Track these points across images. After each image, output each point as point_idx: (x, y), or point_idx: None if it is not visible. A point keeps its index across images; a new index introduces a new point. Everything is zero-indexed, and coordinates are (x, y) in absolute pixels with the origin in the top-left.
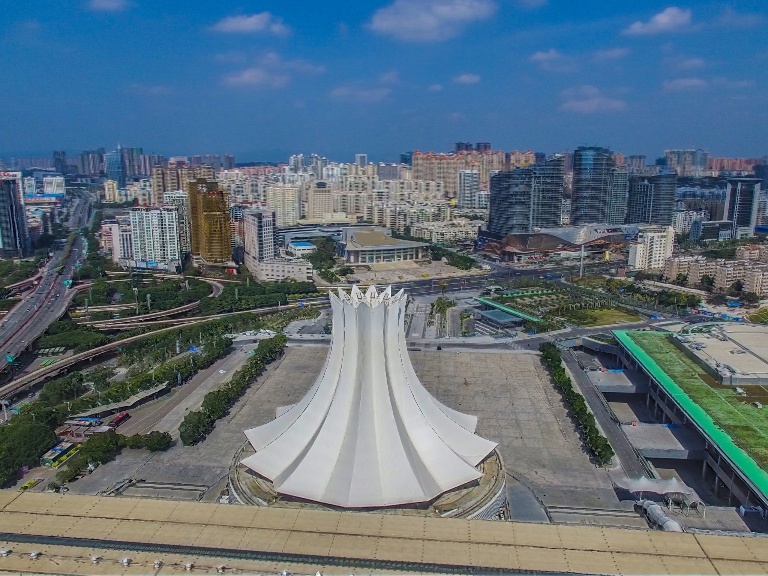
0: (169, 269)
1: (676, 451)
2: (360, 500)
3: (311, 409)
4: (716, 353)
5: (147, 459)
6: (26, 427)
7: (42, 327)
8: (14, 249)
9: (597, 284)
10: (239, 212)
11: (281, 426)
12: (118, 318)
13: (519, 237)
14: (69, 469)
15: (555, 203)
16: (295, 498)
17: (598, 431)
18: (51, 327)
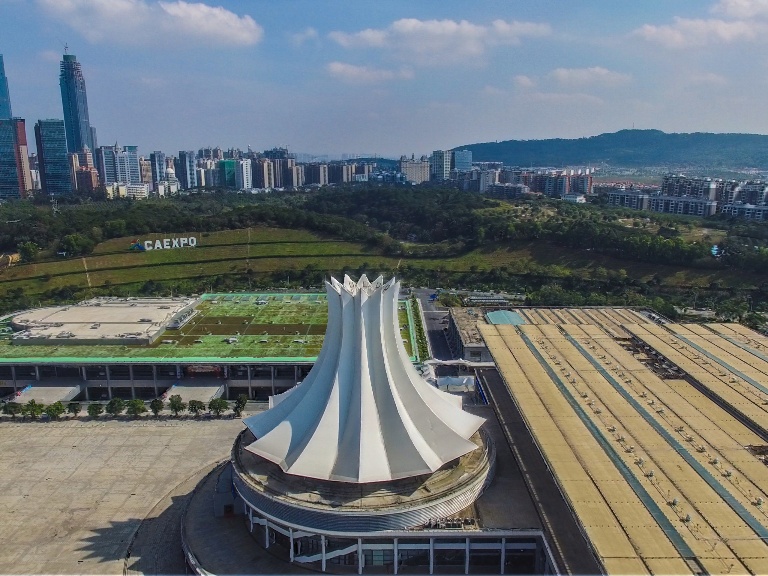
0: None
1: None
2: None
3: None
4: (88, 333)
5: None
6: None
7: None
8: None
9: None
10: None
11: (371, 447)
12: None
13: None
14: None
15: None
16: (456, 459)
17: None
18: None
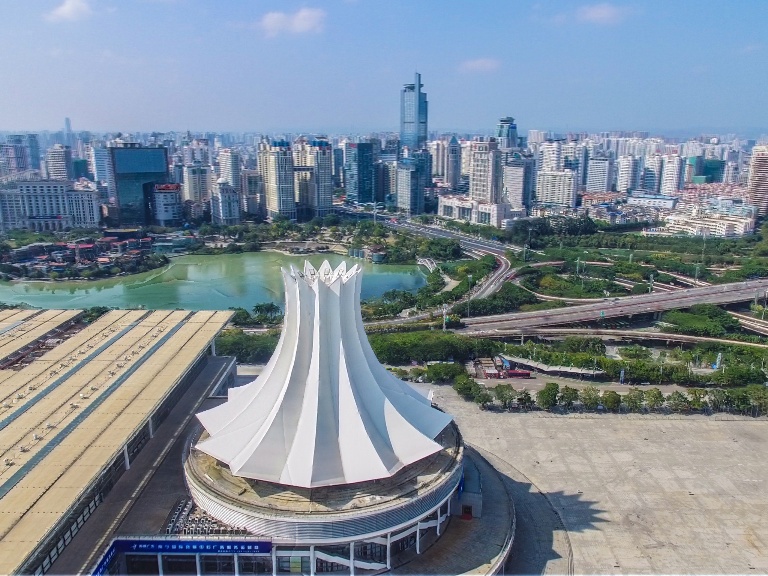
0: None
1: None
2: (208, 419)
3: None
4: None
5: (446, 396)
6: None
7: (689, 304)
8: None
9: None
10: None
11: None
12: None
13: None
14: None
15: None
16: None
17: None
18: (694, 306)
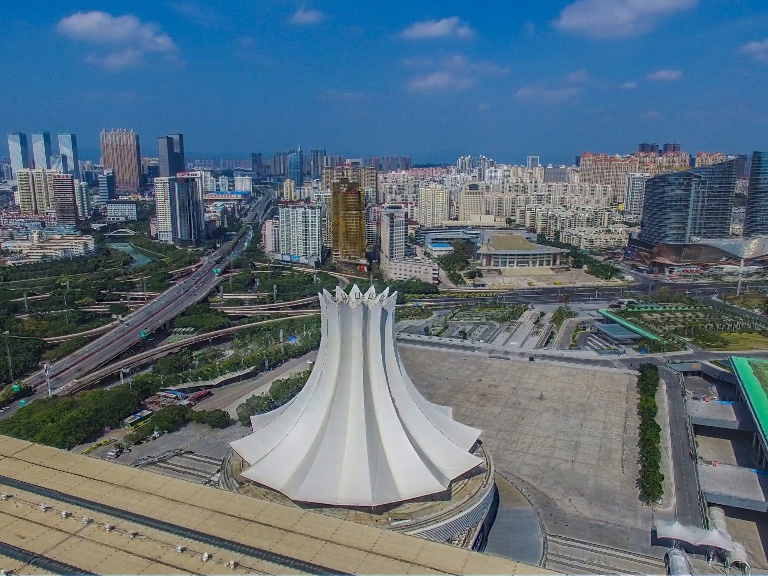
0: (309, 263)
1: (752, 501)
2: (310, 495)
3: (298, 402)
4: None
5: (205, 434)
6: (117, 393)
7: (181, 309)
8: (189, 239)
9: (754, 304)
10: (377, 212)
11: None
12: (247, 305)
13: (672, 247)
14: (136, 433)
15: (723, 211)
16: None
17: (658, 465)
18: (187, 309)
